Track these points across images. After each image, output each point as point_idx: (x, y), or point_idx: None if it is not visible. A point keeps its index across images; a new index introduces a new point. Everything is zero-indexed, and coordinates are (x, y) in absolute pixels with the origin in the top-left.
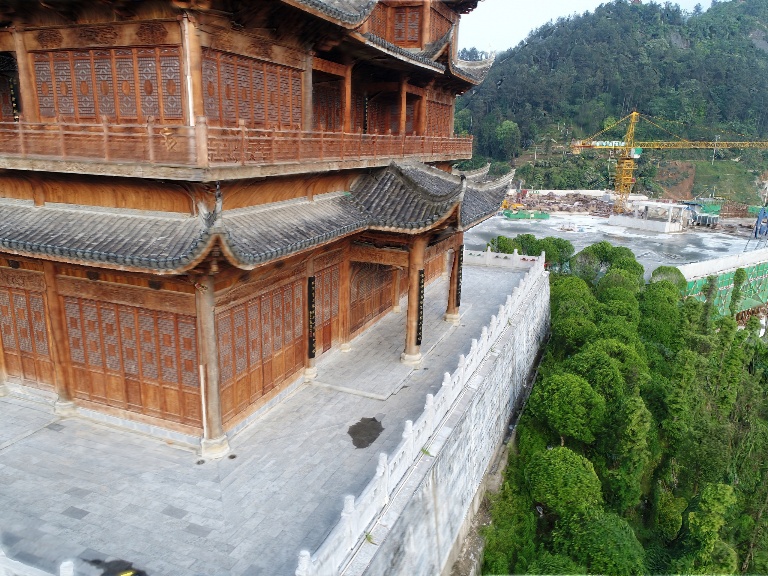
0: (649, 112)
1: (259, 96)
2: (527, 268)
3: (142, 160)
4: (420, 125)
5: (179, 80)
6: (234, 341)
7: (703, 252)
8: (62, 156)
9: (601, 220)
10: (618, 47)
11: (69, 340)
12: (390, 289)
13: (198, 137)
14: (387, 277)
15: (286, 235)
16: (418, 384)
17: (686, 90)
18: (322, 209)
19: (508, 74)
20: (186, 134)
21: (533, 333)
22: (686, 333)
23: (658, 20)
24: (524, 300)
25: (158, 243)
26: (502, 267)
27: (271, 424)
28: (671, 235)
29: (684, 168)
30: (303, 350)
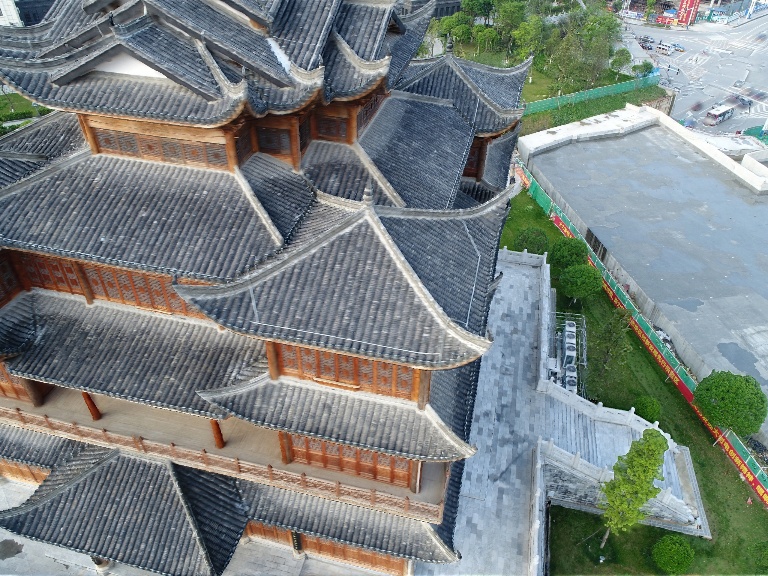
0: None
1: None
2: None
3: None
4: None
5: None
6: None
7: None
8: None
9: None
10: None
11: None
12: None
13: None
14: None
15: None
16: (70, 575)
17: None
18: (38, 436)
19: None
20: None
21: None
22: None
23: None
24: None
25: None
26: None
27: (27, 496)
28: None
29: None
30: None
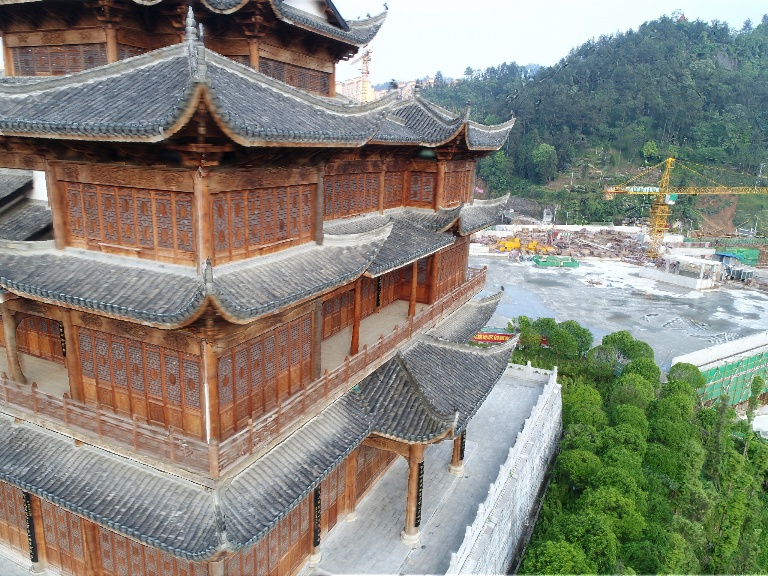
0: (691, 137)
1: (271, 357)
2: (539, 381)
3: (164, 457)
4: (432, 279)
5: (198, 381)
6: (242, 570)
7: (732, 320)
8: (98, 435)
9: (632, 269)
10: (661, 68)
11: (101, 550)
12: None
13: (210, 455)
14: None
15: (290, 484)
16: (414, 571)
17: (731, 115)
18: (328, 425)
19: (547, 95)
20: (201, 448)
21: (539, 463)
22: (688, 477)
23: (704, 39)
24: (530, 436)
25: (176, 520)
26: (515, 377)
27: None
28: (702, 293)
29: (726, 196)
30: (309, 540)
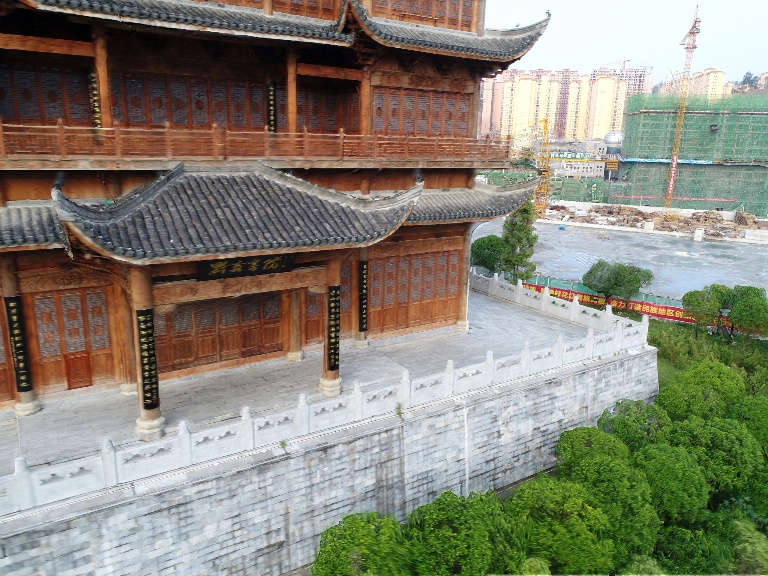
0: None
1: None
2: None
3: None
4: (360, 120)
5: None
6: None
7: None
8: None
9: None
10: None
11: None
12: (276, 329)
13: None
14: (265, 313)
15: None
16: None
17: None
18: None
19: None
20: None
21: (533, 436)
22: None
23: None
24: (503, 383)
25: None
26: None
27: None
28: None
29: None
30: (10, 380)
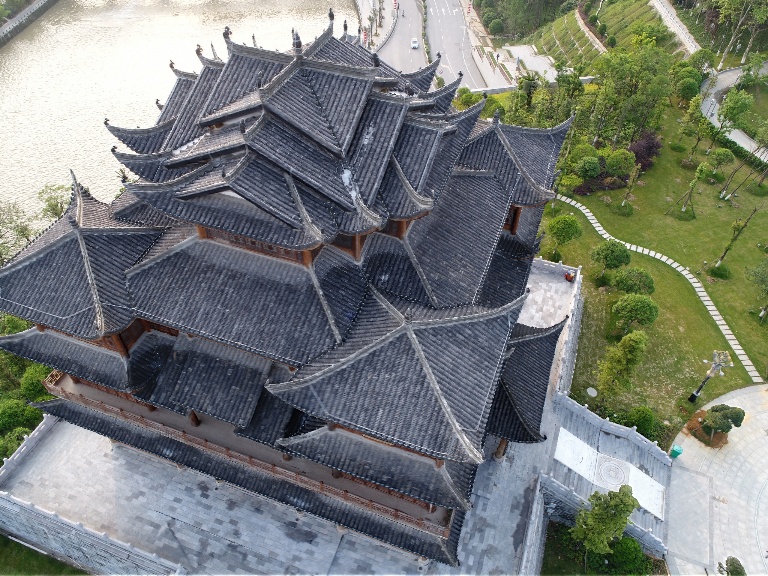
0: None
1: None
2: None
3: None
4: None
5: None
6: None
7: None
8: None
9: None
10: None
11: None
12: None
13: None
14: None
15: None
16: None
17: None
18: None
19: None
20: None
21: None
22: None
23: None
24: None
25: None
26: None
27: None
28: None
29: None
30: None
